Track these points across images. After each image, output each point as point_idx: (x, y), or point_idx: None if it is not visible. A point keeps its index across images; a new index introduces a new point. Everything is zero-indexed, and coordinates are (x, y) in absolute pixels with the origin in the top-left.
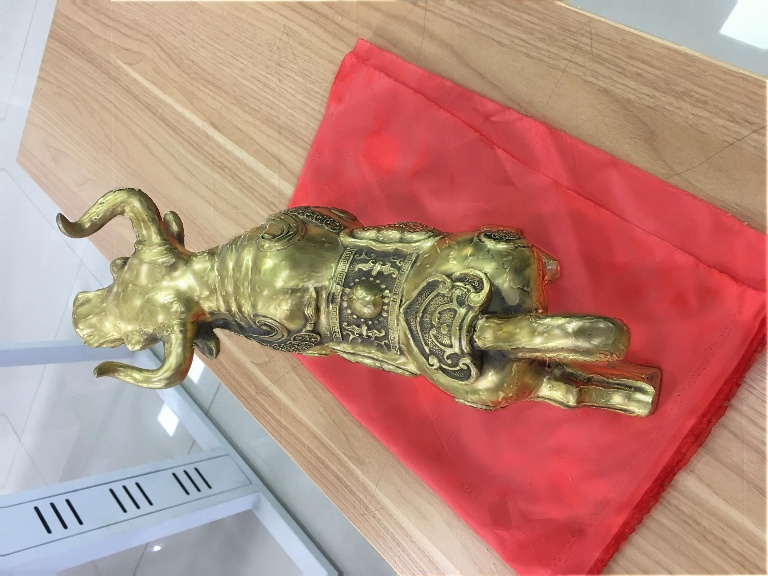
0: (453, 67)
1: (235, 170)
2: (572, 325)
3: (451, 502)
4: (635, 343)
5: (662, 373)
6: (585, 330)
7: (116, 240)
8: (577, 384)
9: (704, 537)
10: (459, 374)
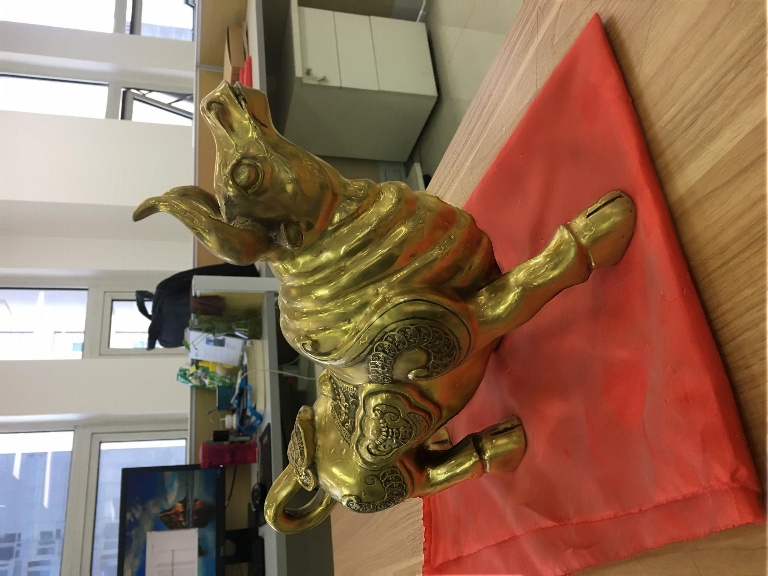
0: None
1: None
2: None
3: None
4: None
5: None
6: None
7: None
8: None
9: None
10: None
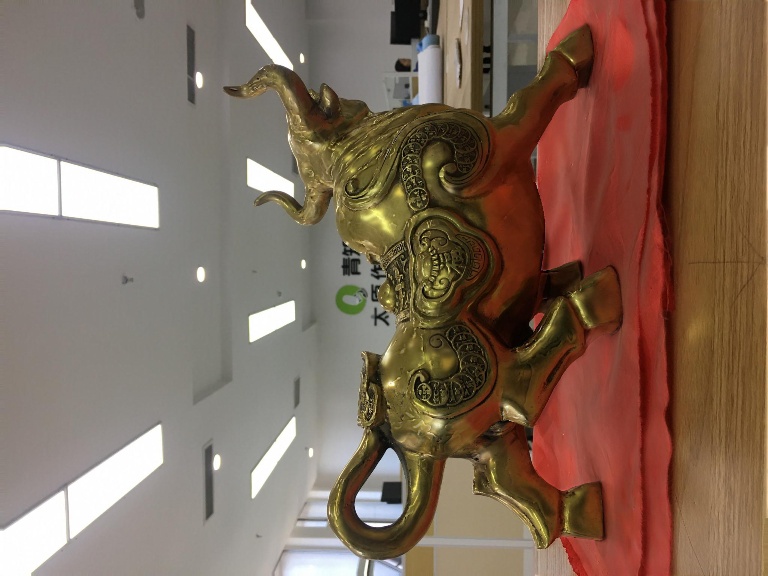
0: (688, 53)
1: None
2: None
3: None
4: None
5: (605, 540)
6: None
7: None
8: (479, 489)
9: None
10: None
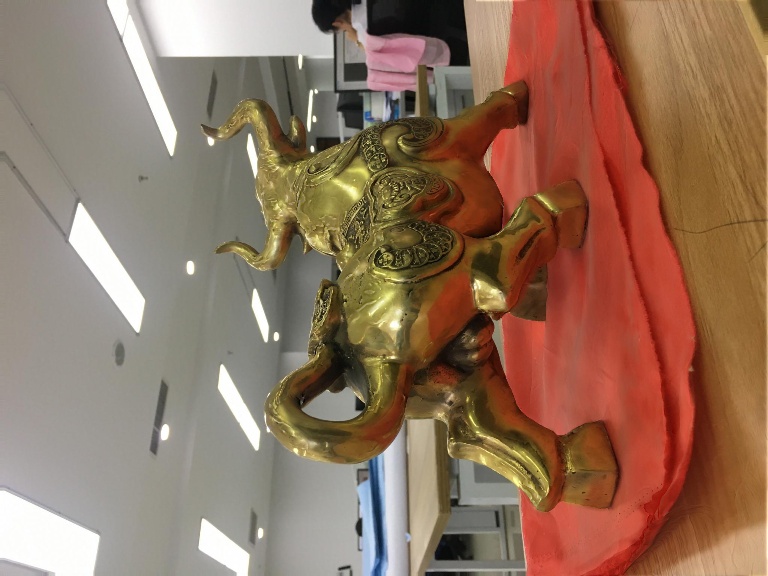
0: None
1: (504, 1)
2: (267, 415)
3: None
4: (616, 421)
5: (620, 475)
6: (273, 426)
7: (472, 42)
8: (457, 438)
9: None
10: None
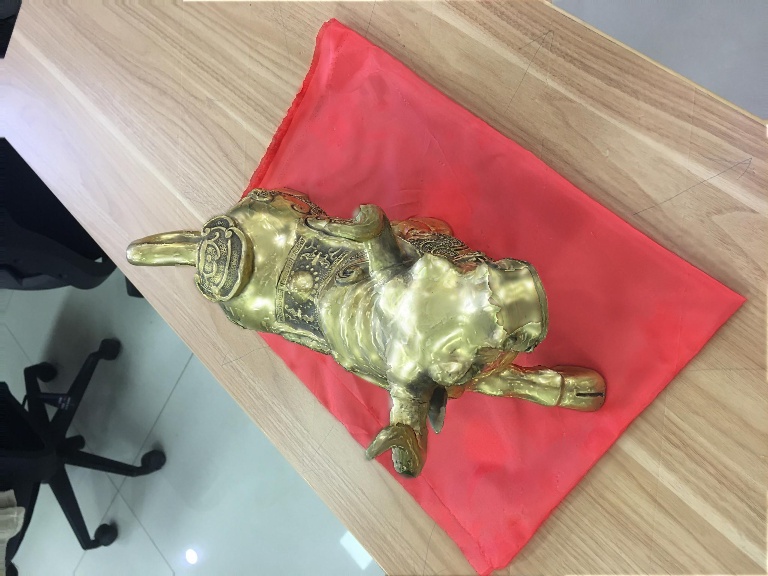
0: (403, 495)
1: (762, 525)
2: None
3: (417, 85)
4: None
5: None
6: None
7: None
8: None
9: (264, 109)
10: (219, 223)
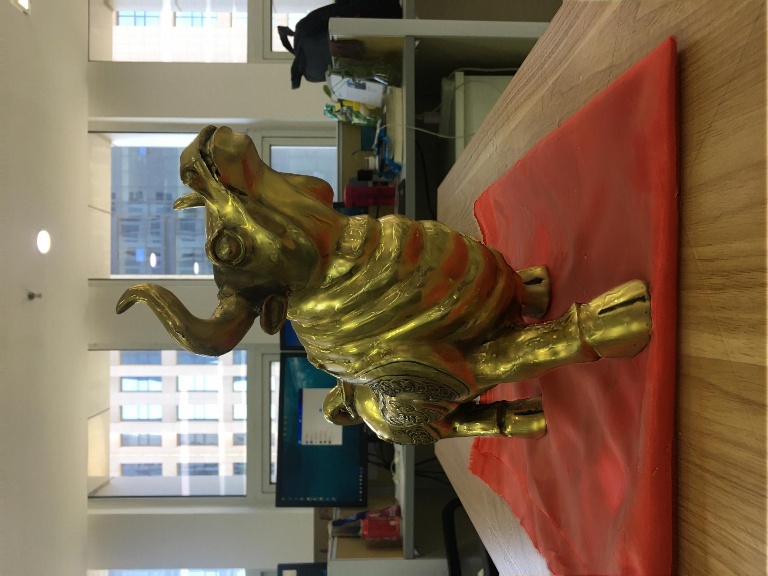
0: None
1: None
2: None
3: None
4: None
5: None
6: None
7: None
8: None
9: None
10: None
